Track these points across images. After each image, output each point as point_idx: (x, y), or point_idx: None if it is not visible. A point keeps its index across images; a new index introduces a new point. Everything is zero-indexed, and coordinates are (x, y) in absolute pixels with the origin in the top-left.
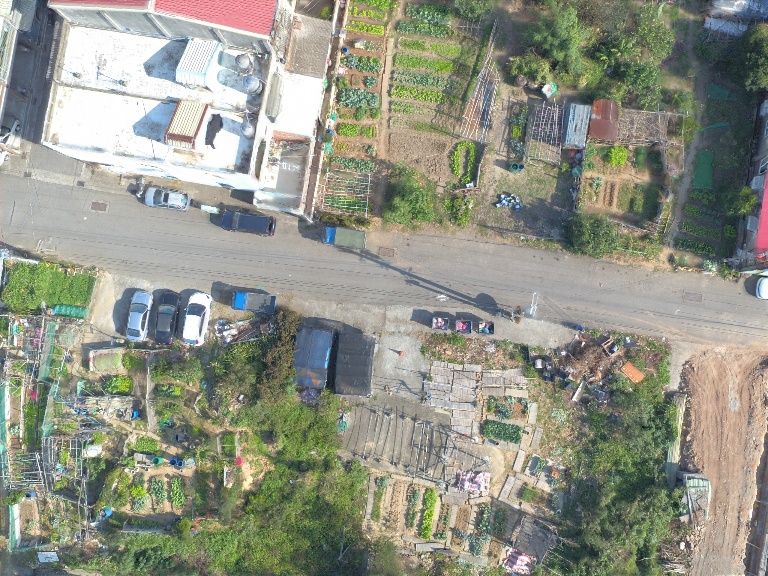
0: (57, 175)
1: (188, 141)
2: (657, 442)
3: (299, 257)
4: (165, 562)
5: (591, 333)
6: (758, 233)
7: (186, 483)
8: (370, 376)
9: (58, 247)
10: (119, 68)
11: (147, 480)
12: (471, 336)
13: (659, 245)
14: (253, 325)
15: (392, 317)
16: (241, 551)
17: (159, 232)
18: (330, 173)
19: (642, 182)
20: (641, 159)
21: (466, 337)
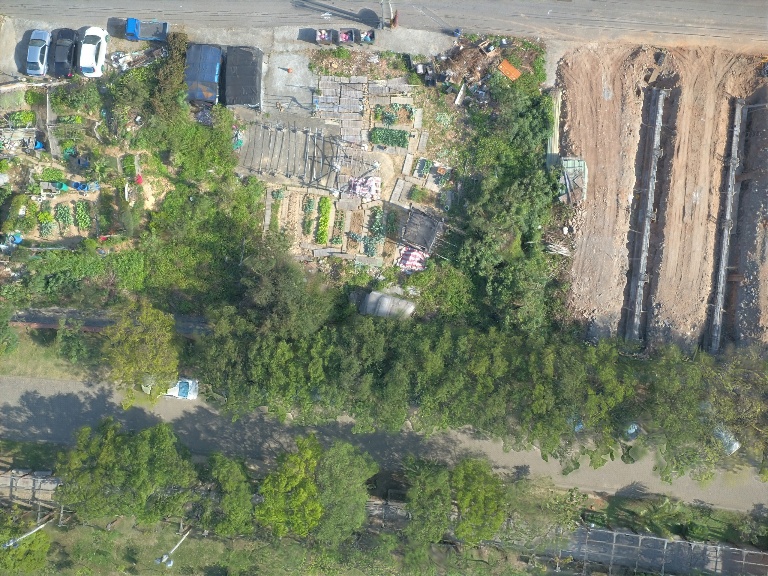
0: None
1: None
2: (535, 131)
3: None
4: (74, 282)
5: (469, 38)
6: None
7: (91, 207)
8: (259, 87)
9: None
10: None
11: (54, 207)
12: (356, 50)
13: None
14: (148, 54)
15: (280, 38)
16: (147, 270)
17: None
18: None
19: None
20: None
21: (351, 51)
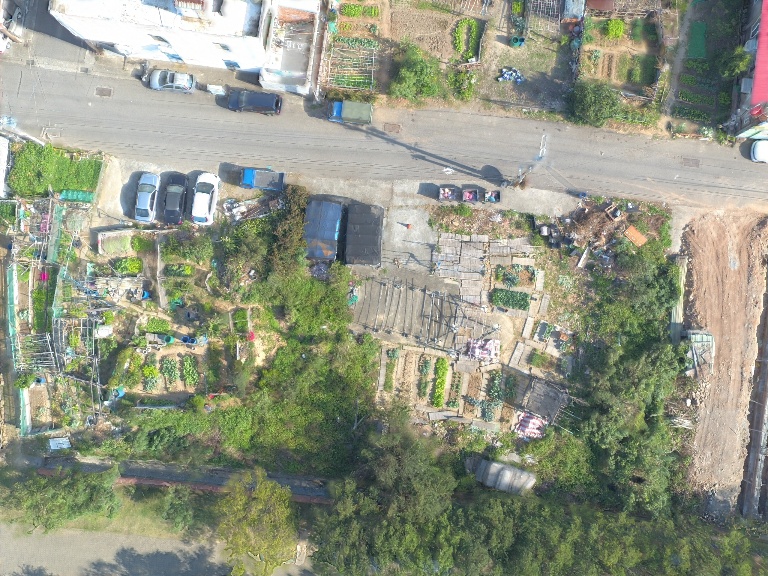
0: (60, 62)
1: (197, 2)
2: (661, 302)
3: (305, 135)
4: (180, 440)
5: (594, 200)
6: (752, 91)
7: (199, 361)
8: (380, 246)
9: (63, 133)
10: None
11: (159, 360)
12: (477, 207)
13: (657, 114)
14: (262, 203)
15: (399, 191)
16: (255, 427)
17: (165, 115)
18: (335, 48)
19: (638, 53)
20: (637, 31)
21: (472, 208)
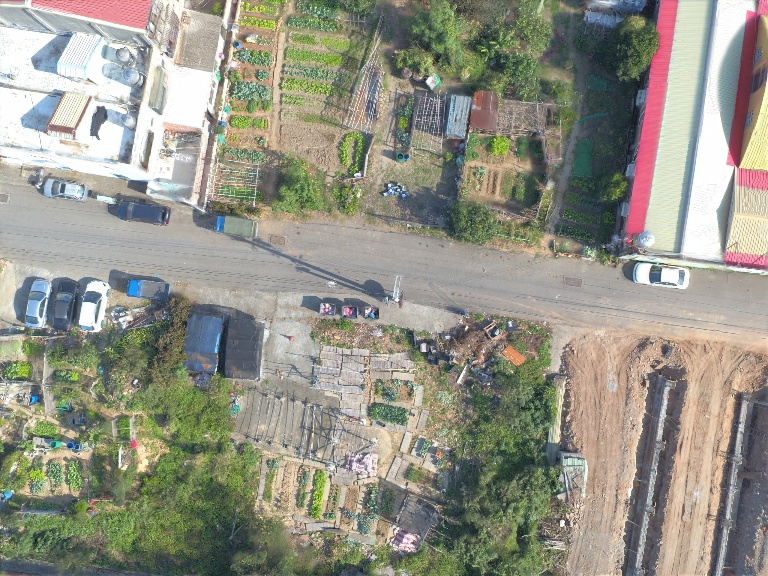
0: None
1: (69, 132)
2: (536, 423)
3: (193, 246)
4: (63, 543)
5: (475, 318)
6: (628, 219)
7: (83, 466)
8: (259, 360)
9: None
10: (8, 62)
11: (46, 463)
12: (359, 321)
13: (540, 232)
14: (149, 312)
15: (283, 303)
16: (137, 532)
17: (58, 222)
18: (220, 163)
19: (524, 171)
20: (523, 148)
21: (354, 322)
